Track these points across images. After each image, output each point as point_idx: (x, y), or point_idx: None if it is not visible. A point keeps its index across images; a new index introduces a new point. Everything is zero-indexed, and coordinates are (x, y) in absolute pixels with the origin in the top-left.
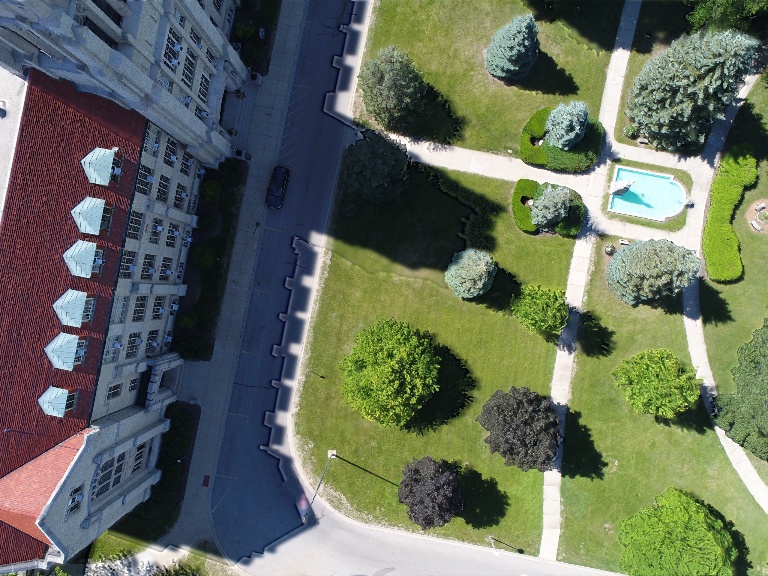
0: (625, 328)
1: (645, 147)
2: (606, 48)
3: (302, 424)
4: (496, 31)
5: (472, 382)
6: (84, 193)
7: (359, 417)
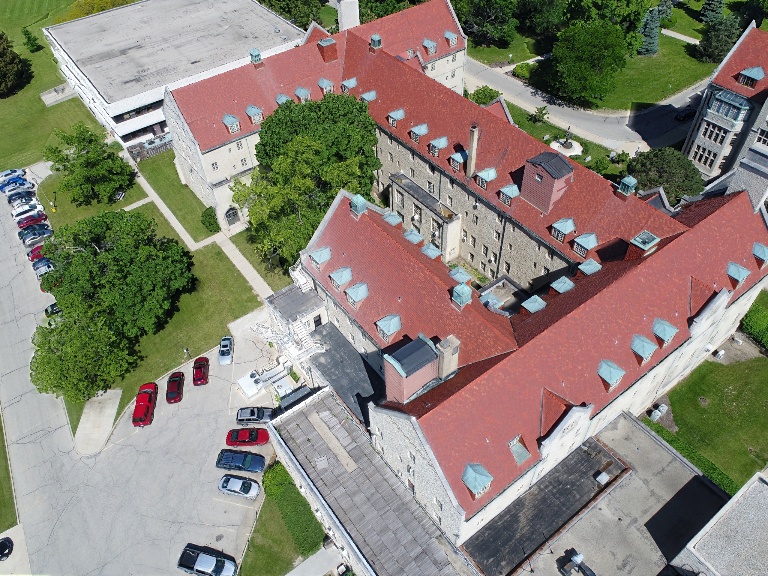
0: None
1: None
2: None
3: None
4: (644, 58)
5: (726, 4)
6: None
7: None
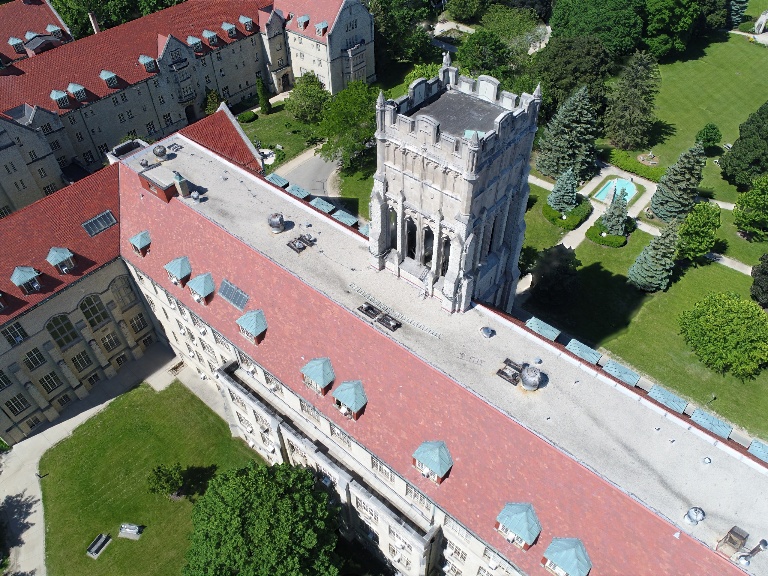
0: None
1: (586, 184)
2: None
3: (761, 433)
4: None
5: None
6: None
7: (759, 389)
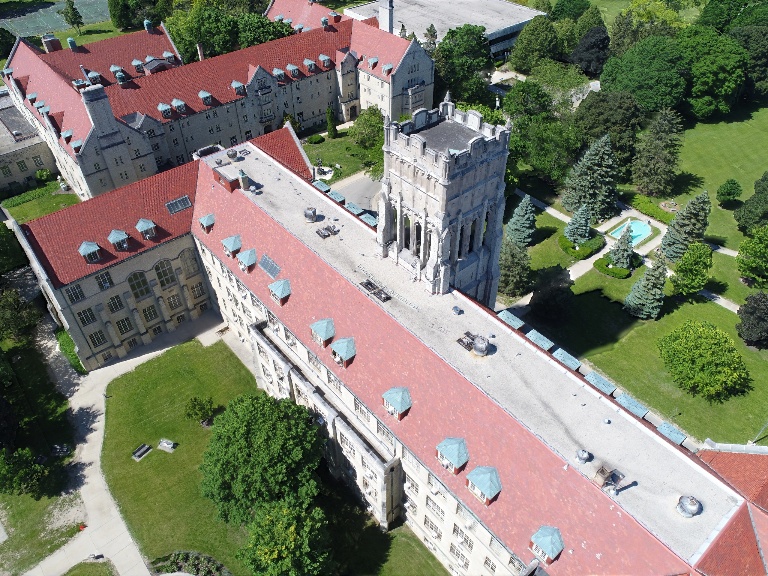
0: (712, 272)
1: (605, 222)
2: (541, 211)
3: None
4: None
5: None
6: None
7: (724, 412)
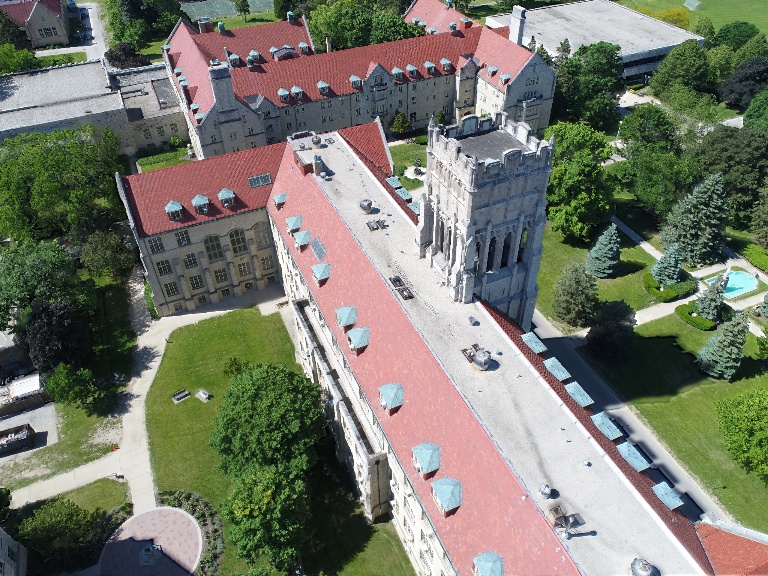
0: None
1: (704, 267)
2: (635, 245)
3: None
4: None
5: None
6: (540, 359)
7: None
